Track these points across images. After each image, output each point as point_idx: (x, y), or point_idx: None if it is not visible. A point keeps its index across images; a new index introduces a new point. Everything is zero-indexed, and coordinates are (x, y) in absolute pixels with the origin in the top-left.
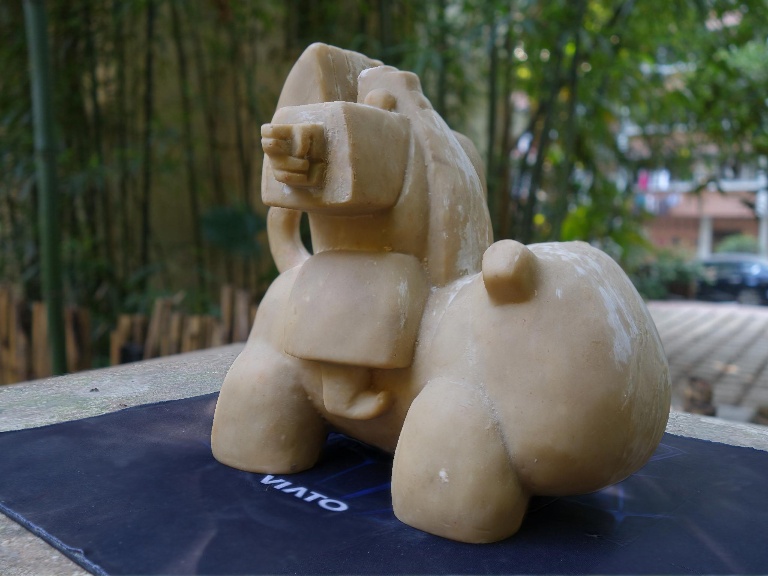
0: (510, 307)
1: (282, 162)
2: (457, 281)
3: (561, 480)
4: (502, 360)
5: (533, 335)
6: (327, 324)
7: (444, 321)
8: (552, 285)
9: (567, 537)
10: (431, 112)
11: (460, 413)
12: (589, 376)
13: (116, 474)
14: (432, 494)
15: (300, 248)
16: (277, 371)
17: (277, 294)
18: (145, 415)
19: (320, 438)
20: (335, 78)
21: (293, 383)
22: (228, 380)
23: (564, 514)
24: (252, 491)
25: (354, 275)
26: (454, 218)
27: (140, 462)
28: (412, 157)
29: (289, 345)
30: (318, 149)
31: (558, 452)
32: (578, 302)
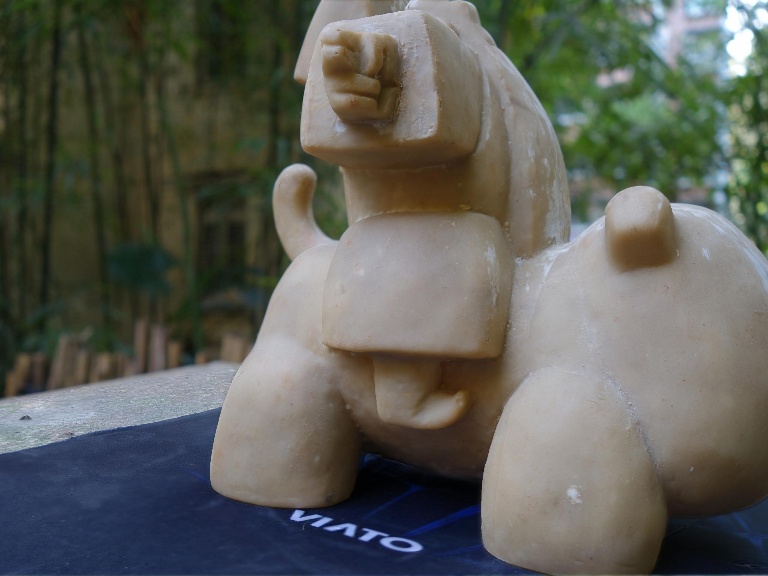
0: (644, 272)
1: (347, 81)
2: (546, 251)
3: (718, 495)
4: (639, 340)
5: (681, 306)
6: (393, 303)
7: (544, 297)
8: (695, 244)
9: (717, 570)
10: (500, 50)
11: (590, 411)
12: (757, 356)
13: (88, 518)
14: (557, 521)
15: (315, 227)
16: (307, 373)
17: (301, 276)
18: (103, 444)
19: (357, 460)
20: (380, 6)
21: (328, 388)
22: (238, 387)
23: (691, 541)
24: (285, 532)
25: (427, 239)
26: (541, 173)
27: (117, 501)
28: (488, 97)
29: (334, 334)
30: (392, 68)
31: (723, 457)
32: (729, 265)
